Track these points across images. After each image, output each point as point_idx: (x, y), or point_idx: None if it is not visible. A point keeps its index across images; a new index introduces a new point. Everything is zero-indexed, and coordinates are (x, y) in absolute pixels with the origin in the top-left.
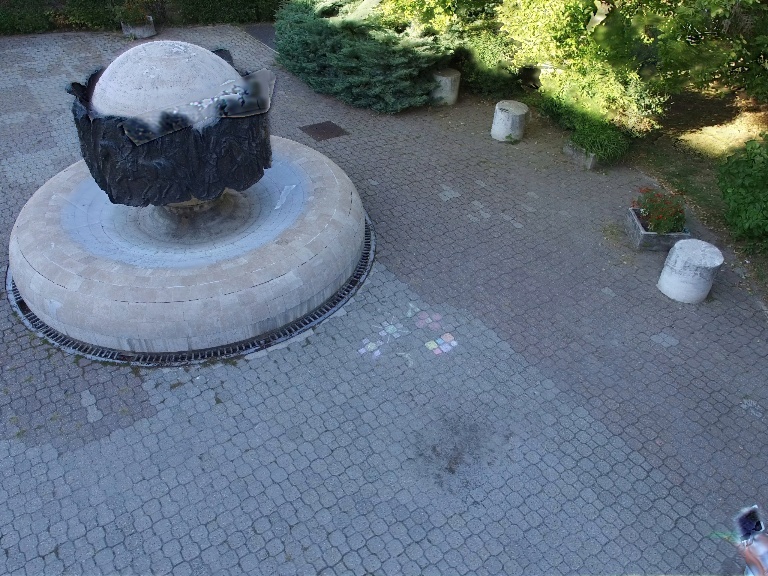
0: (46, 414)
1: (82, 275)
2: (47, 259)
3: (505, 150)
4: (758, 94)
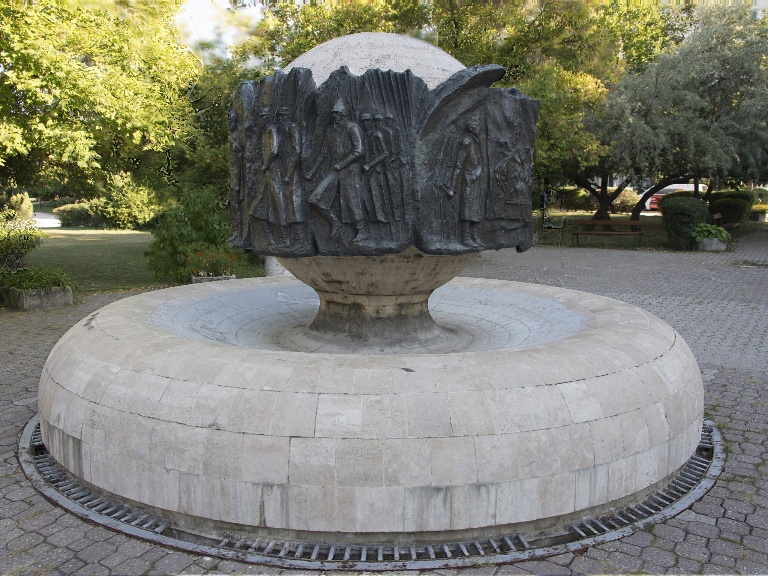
0: (759, 386)
1: (631, 306)
2: (651, 320)
3: (4, 326)
4: (148, 180)
